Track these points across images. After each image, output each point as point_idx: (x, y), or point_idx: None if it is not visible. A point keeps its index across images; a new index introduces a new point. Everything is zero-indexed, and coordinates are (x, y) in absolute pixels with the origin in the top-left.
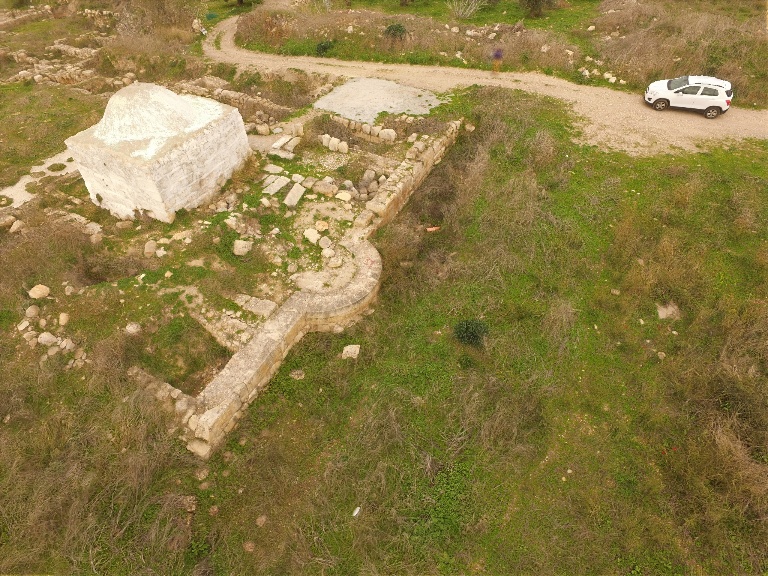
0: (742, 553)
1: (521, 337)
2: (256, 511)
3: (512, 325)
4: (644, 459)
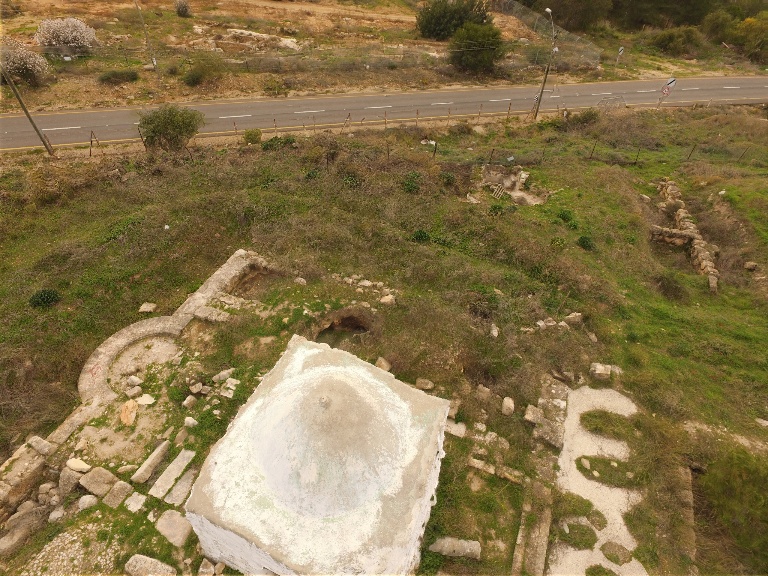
0: (0, 220)
1: (8, 300)
2: (220, 238)
3: (6, 307)
4: (3, 247)
